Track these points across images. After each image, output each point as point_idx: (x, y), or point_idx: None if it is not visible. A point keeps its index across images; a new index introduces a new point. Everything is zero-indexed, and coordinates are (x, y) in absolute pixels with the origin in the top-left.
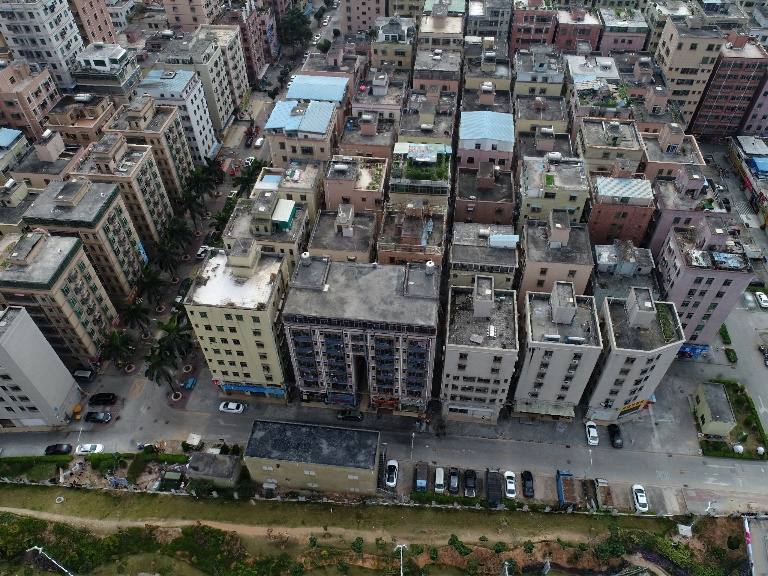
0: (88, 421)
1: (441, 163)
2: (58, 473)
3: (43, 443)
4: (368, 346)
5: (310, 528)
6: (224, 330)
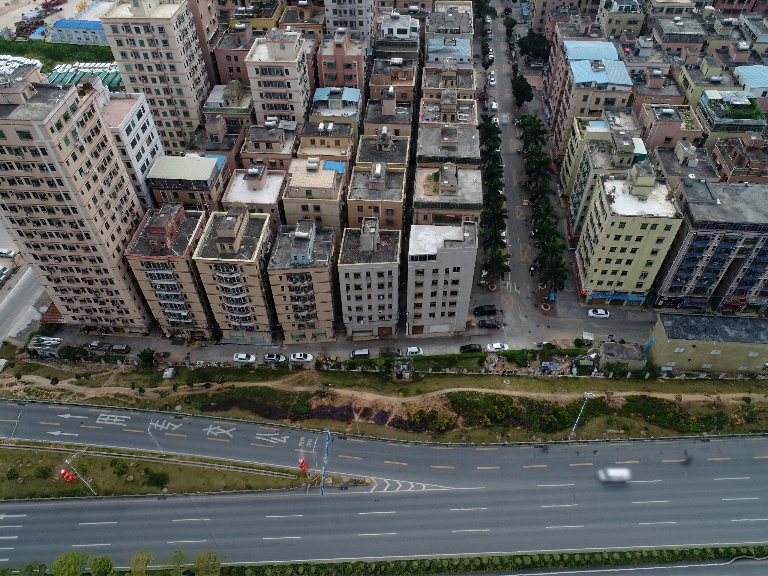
0: (483, 327)
1: (753, 106)
2: (481, 366)
3: (453, 345)
4: (754, 249)
5: (728, 394)
6: (630, 239)
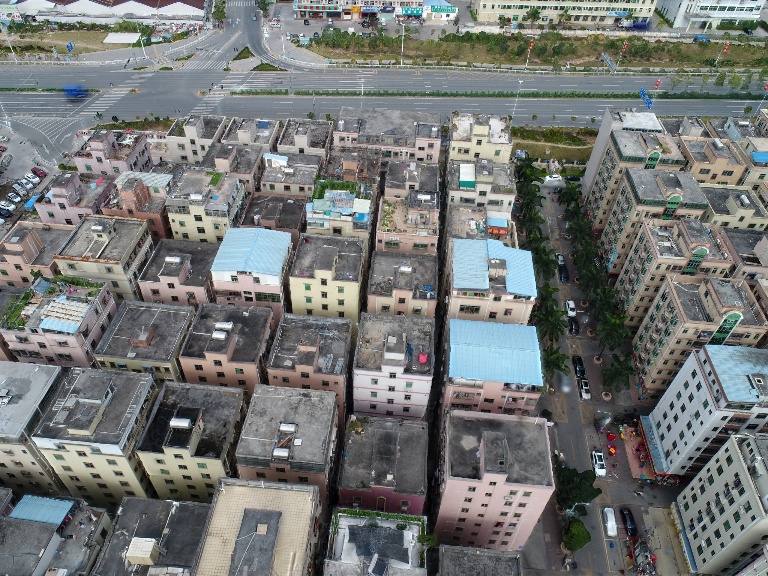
0: None
1: None
2: None
3: None
4: None
5: None
6: None
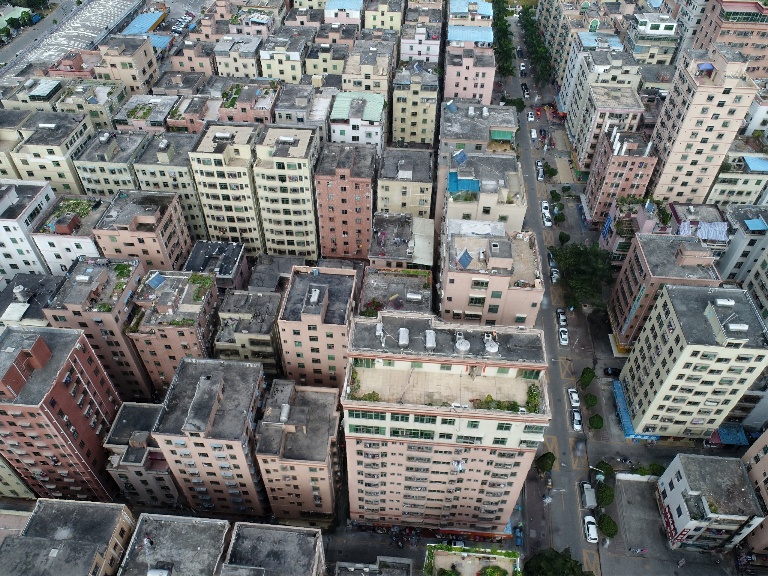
0: None
1: None
2: None
3: None
4: None
5: None
6: None
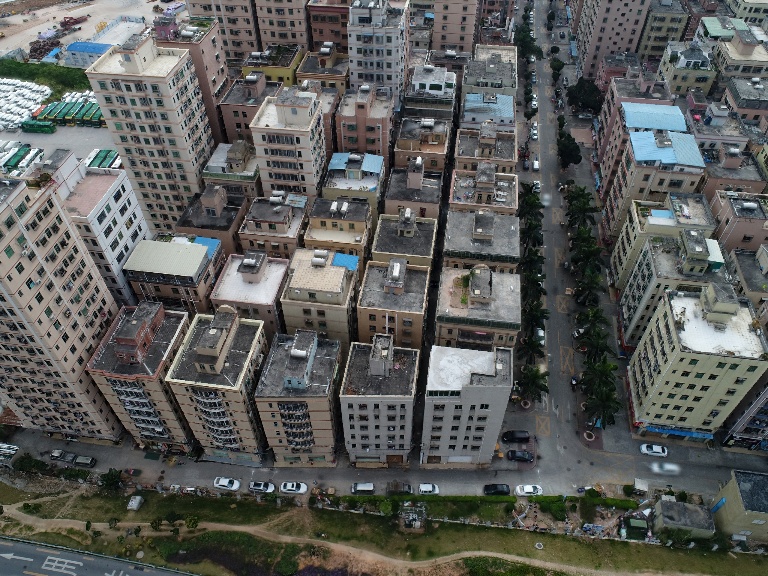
0: (512, 460)
1: None
2: (508, 515)
3: (476, 482)
4: None
5: None
6: (702, 377)
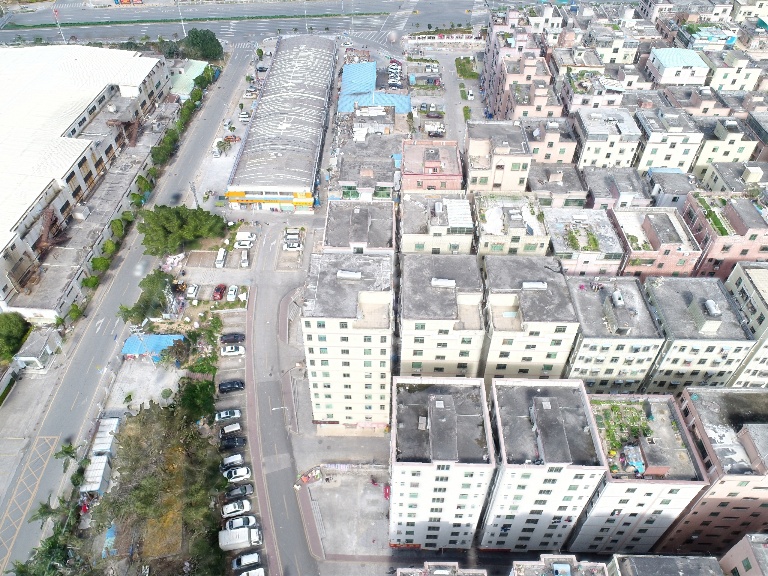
0: None
1: None
2: None
3: None
4: None
5: None
6: None
